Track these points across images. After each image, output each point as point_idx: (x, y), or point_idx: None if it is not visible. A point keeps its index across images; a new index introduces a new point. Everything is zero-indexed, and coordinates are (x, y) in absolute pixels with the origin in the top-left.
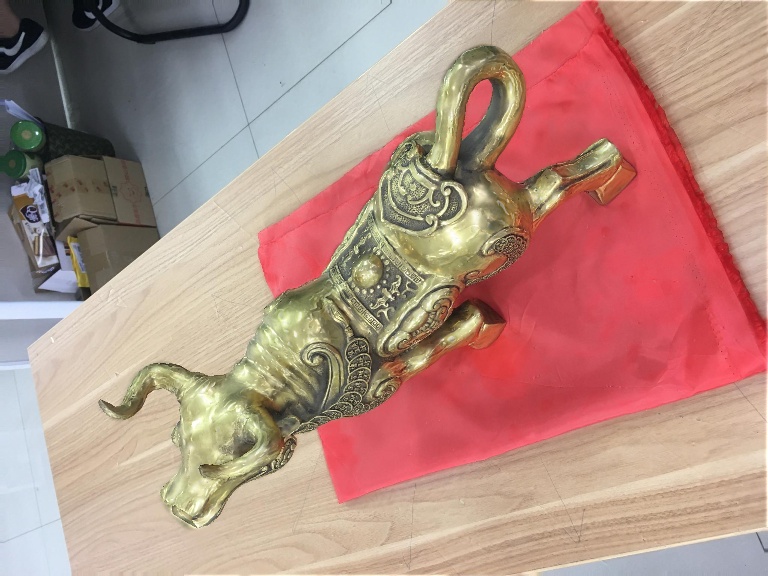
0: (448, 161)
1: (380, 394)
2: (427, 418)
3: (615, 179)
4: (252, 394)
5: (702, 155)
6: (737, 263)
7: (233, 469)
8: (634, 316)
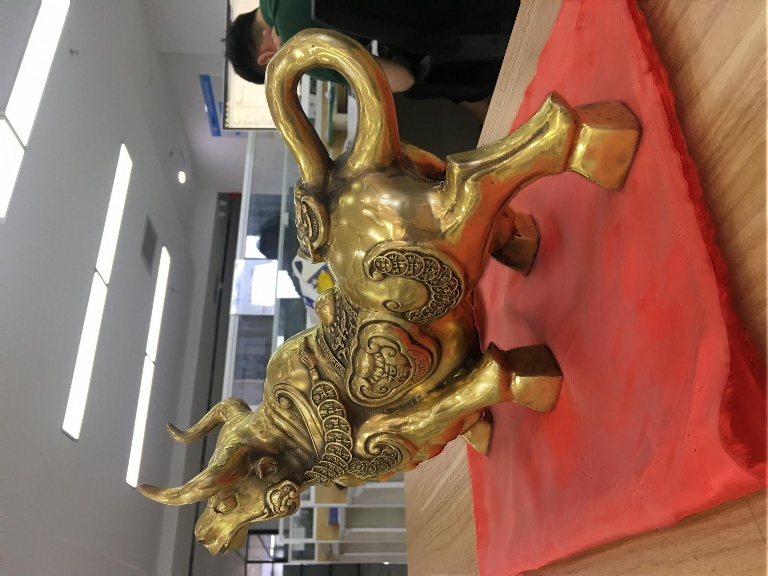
0: (309, 173)
1: (376, 451)
2: (520, 500)
3: (589, 148)
4: (246, 431)
5: (698, 71)
6: (742, 261)
7: (174, 496)
8: (647, 367)
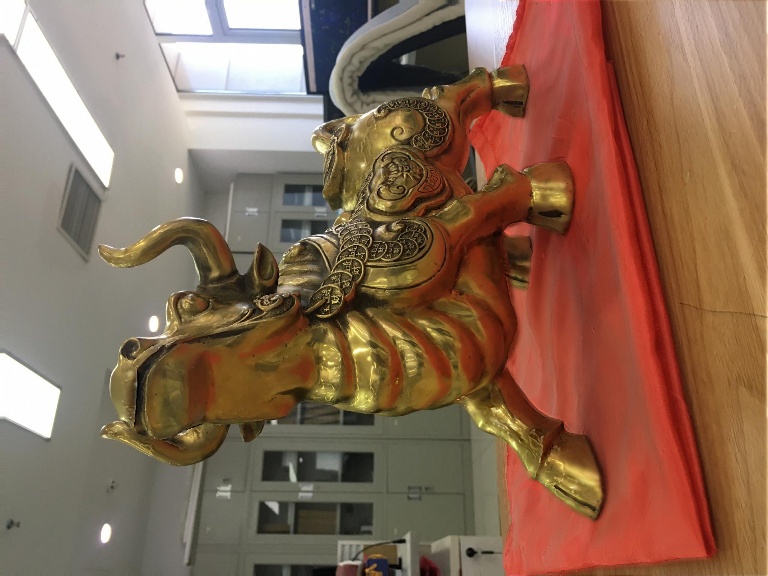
0: None
1: None
2: (609, 273)
3: None
4: None
5: None
6: None
7: None
8: (562, 7)
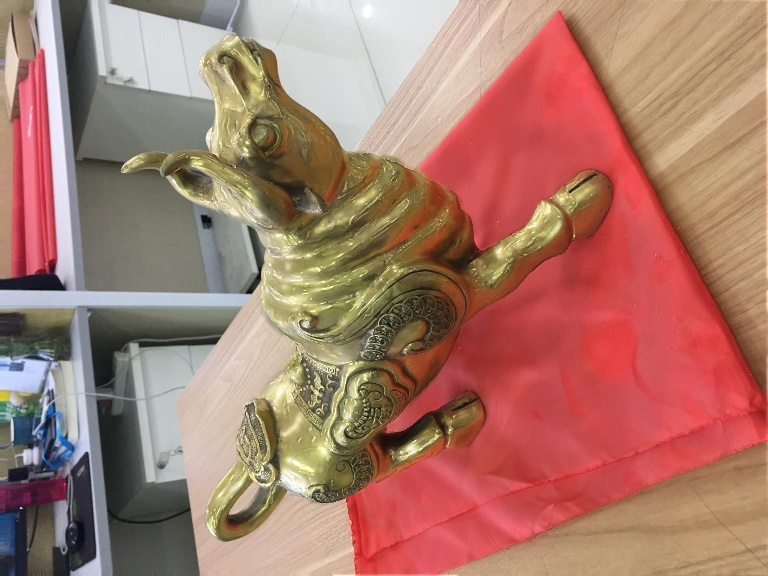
0: None
1: None
2: (467, 191)
3: None
4: None
5: None
6: None
7: None
8: None
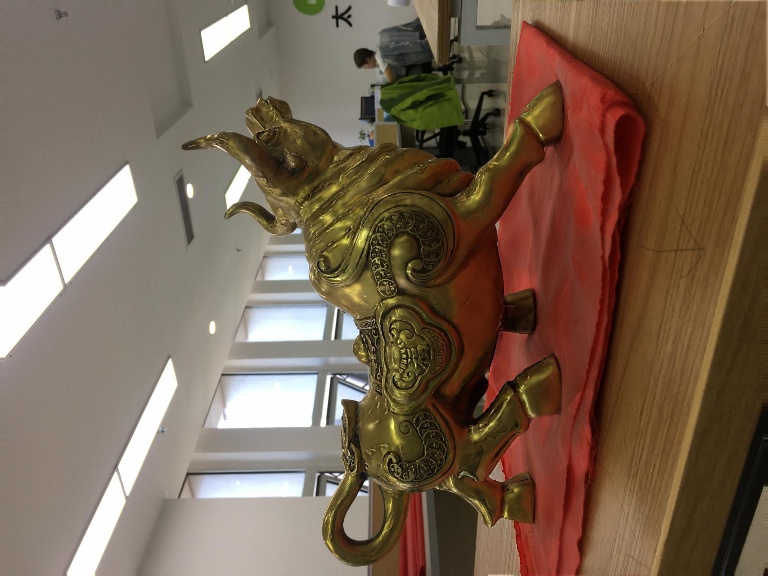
0: None
1: None
2: None
3: None
4: None
5: None
6: None
7: None
8: None
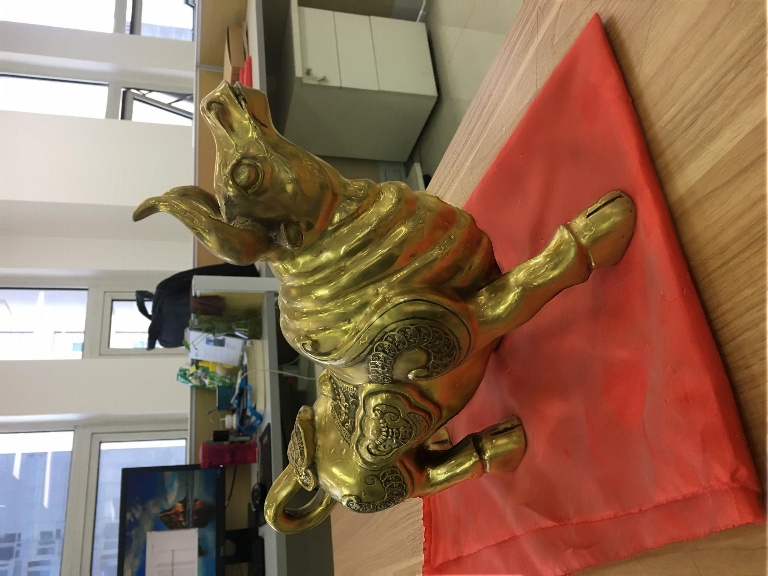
0: None
1: None
2: (519, 207)
3: None
4: None
5: None
6: None
7: None
8: None
